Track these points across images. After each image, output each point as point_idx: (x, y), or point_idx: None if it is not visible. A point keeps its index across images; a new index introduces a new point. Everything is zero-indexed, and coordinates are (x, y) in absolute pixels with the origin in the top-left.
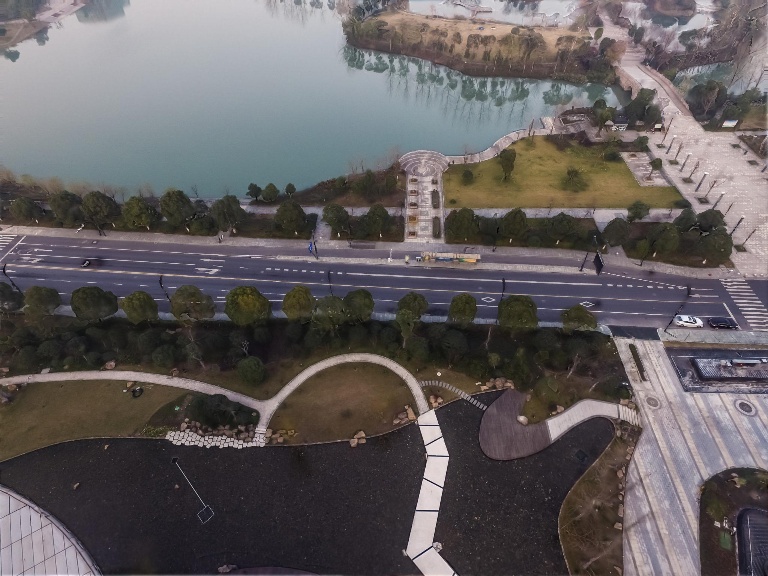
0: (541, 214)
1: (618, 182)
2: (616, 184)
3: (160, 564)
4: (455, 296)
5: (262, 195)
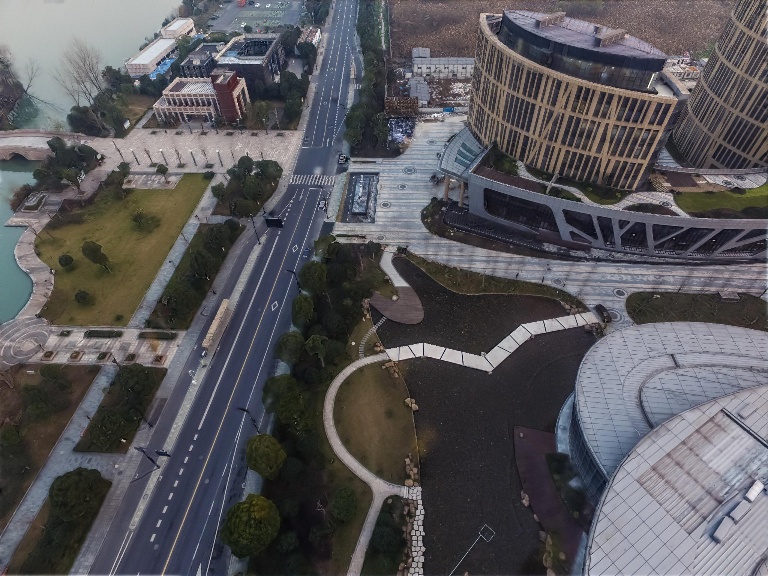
0: (178, 253)
1: (160, 199)
2: (162, 201)
3: (534, 567)
4: (297, 306)
5: None
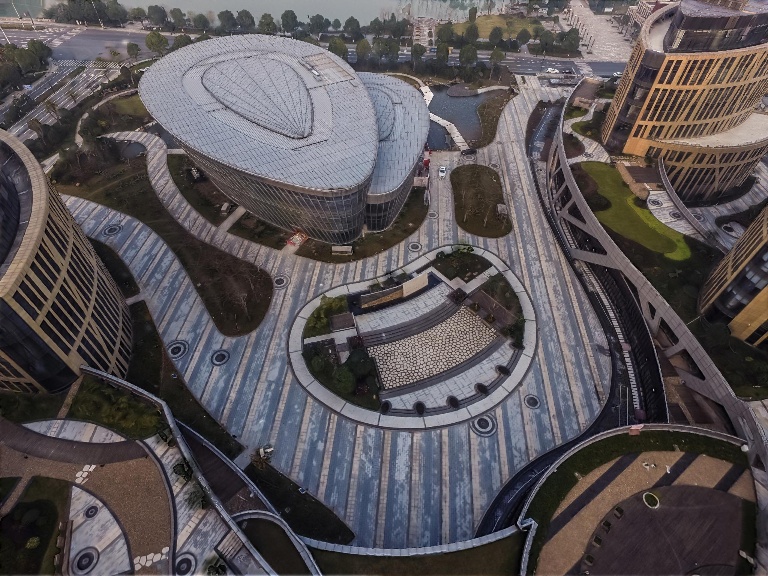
0: None
1: None
2: None
3: None
4: (439, 44)
5: (332, 25)
